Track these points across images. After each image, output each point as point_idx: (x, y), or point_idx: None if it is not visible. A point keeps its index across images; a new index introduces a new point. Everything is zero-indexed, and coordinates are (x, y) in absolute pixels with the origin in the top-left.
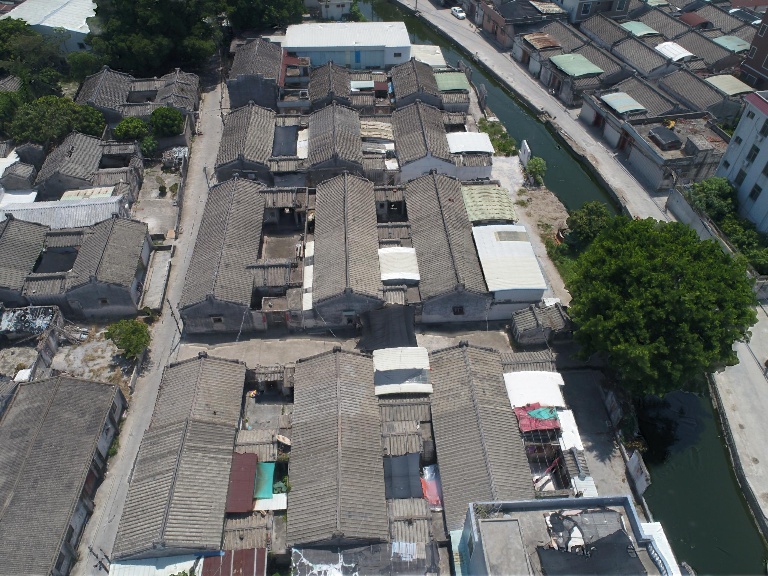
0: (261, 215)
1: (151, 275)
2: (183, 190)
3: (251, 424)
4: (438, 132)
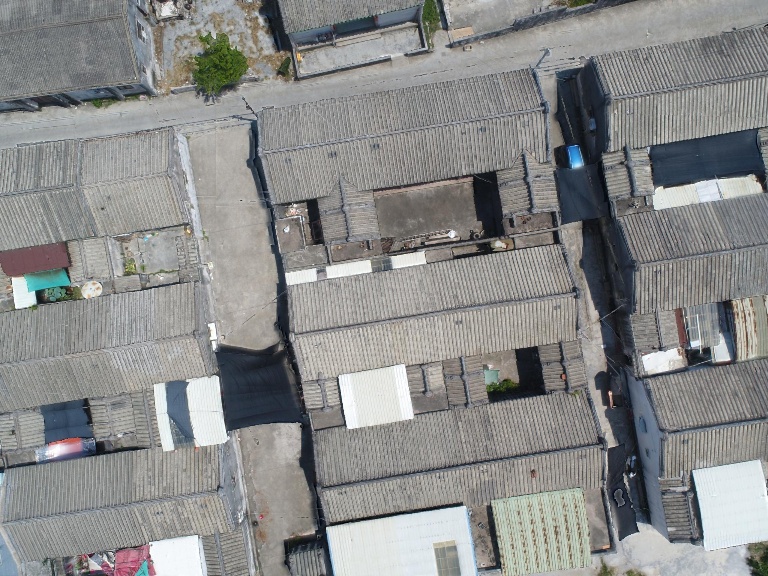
0: (469, 171)
1: (366, 40)
2: (568, 15)
3: (150, 240)
4: (761, 446)
